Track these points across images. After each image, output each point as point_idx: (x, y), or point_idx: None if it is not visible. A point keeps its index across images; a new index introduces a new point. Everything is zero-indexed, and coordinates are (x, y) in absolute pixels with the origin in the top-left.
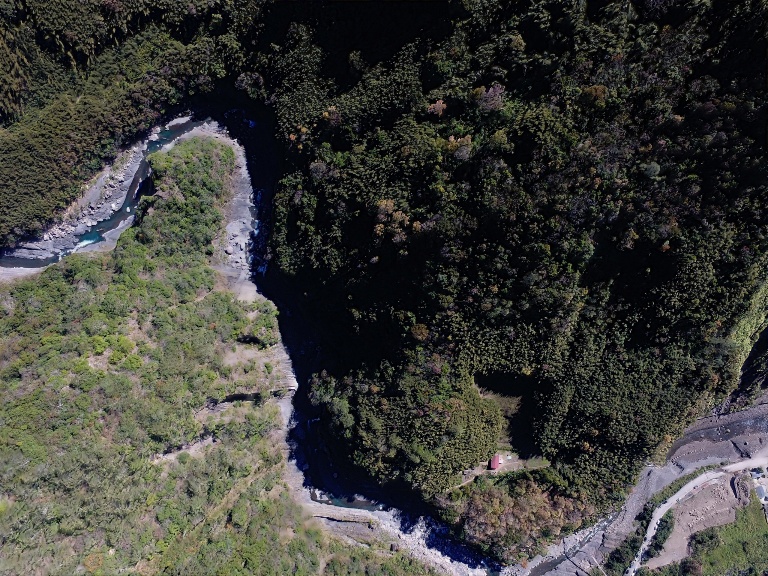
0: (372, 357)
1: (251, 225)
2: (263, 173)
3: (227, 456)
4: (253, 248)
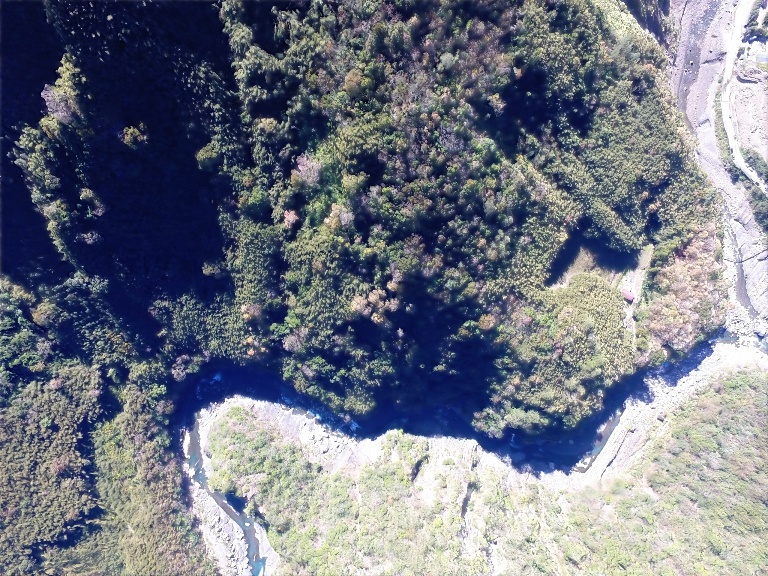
0: (485, 370)
1: (309, 419)
2: (267, 387)
3: (515, 538)
4: (331, 426)
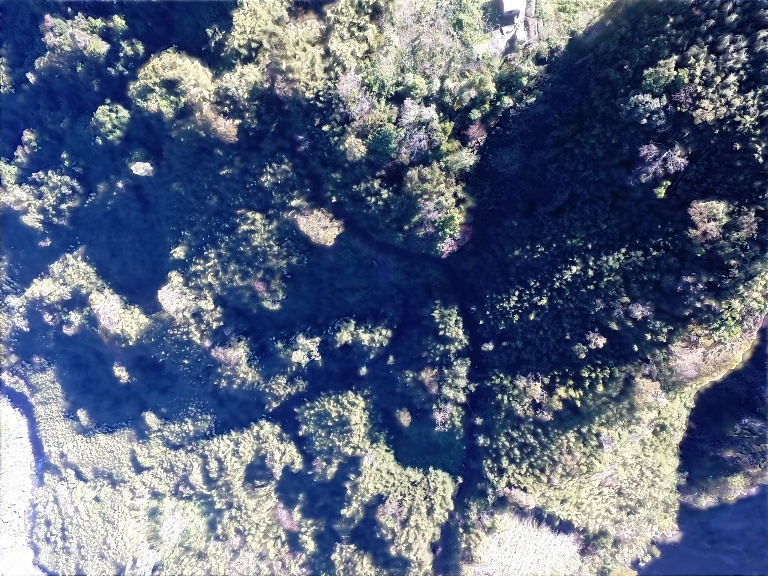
0: None
1: (31, 493)
2: None
3: None
4: (33, 515)
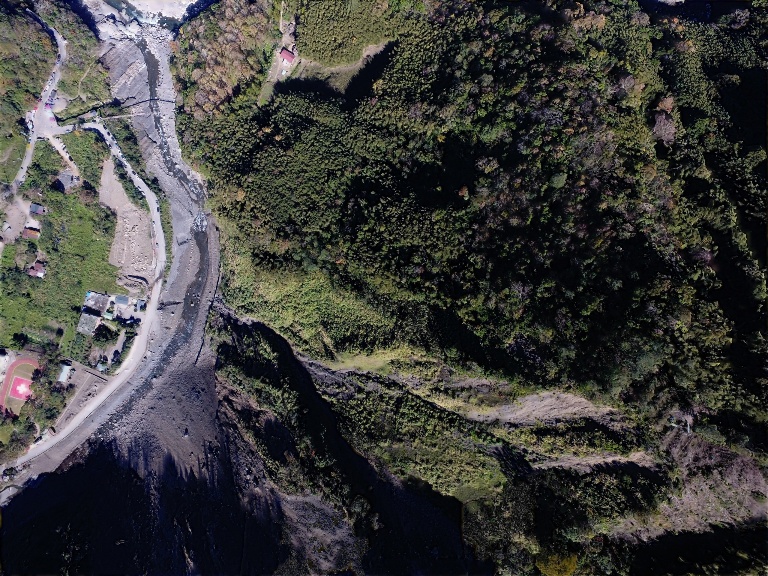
0: None
1: None
2: None
3: None
4: None
